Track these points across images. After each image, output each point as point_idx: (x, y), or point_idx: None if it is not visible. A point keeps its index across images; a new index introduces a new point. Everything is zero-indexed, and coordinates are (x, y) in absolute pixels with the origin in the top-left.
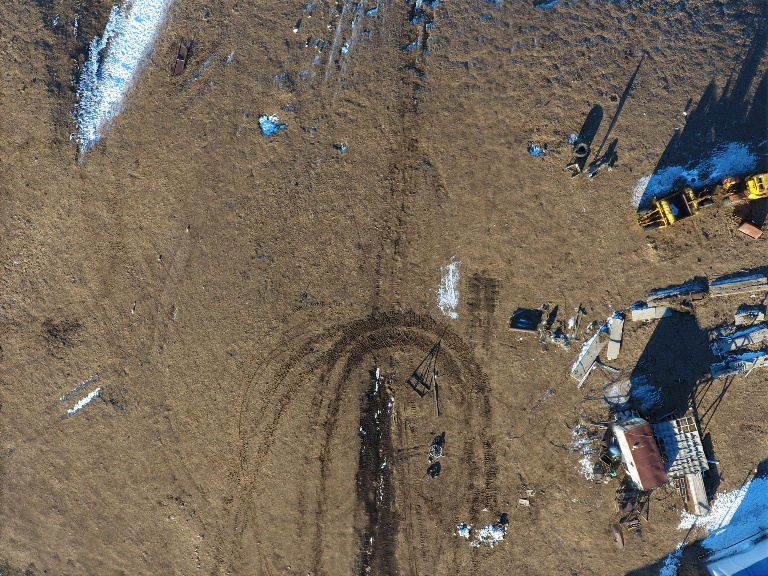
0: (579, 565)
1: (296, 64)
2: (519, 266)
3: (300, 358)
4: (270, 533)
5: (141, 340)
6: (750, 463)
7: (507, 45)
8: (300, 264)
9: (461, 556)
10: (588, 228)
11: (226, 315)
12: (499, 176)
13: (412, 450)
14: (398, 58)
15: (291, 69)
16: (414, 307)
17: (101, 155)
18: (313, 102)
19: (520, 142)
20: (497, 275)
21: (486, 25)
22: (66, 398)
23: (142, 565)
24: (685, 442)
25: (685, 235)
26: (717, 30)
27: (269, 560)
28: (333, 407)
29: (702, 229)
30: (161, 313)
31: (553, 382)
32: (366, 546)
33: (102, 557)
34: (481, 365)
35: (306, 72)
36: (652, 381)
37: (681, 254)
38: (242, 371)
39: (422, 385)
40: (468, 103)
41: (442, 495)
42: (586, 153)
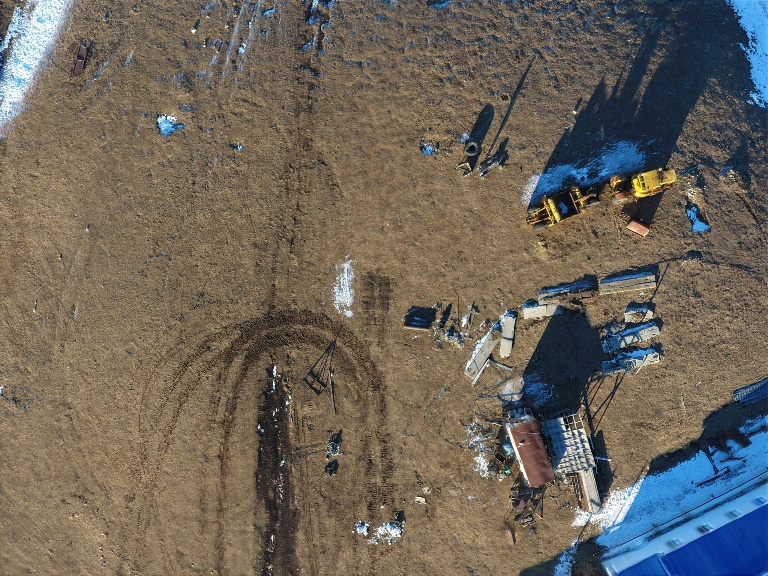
0: (475, 562)
1: (194, 64)
2: (413, 264)
3: (198, 356)
4: (173, 531)
5: (43, 339)
6: (642, 460)
7: (401, 45)
8: (197, 263)
9: (360, 554)
10: (480, 226)
11: (125, 314)
12: (392, 175)
13: (310, 448)
14: (294, 58)
15: (189, 69)
16: (310, 305)
17: (2, 155)
18: (210, 102)
19: (413, 141)
20: (391, 273)
21: (380, 25)
22: None
23: (48, 563)
24: (572, 439)
25: (575, 233)
26: (608, 29)
27: (173, 558)
28: (231, 405)
29: (591, 227)
30: (62, 312)
31: (448, 380)
32: (267, 544)
33: (8, 555)
34: (376, 363)
35: (204, 72)
36: (545, 379)
37: (571, 252)
38: (141, 369)
39: (318, 383)
40: (362, 102)
41: (340, 493)
42: (476, 152)
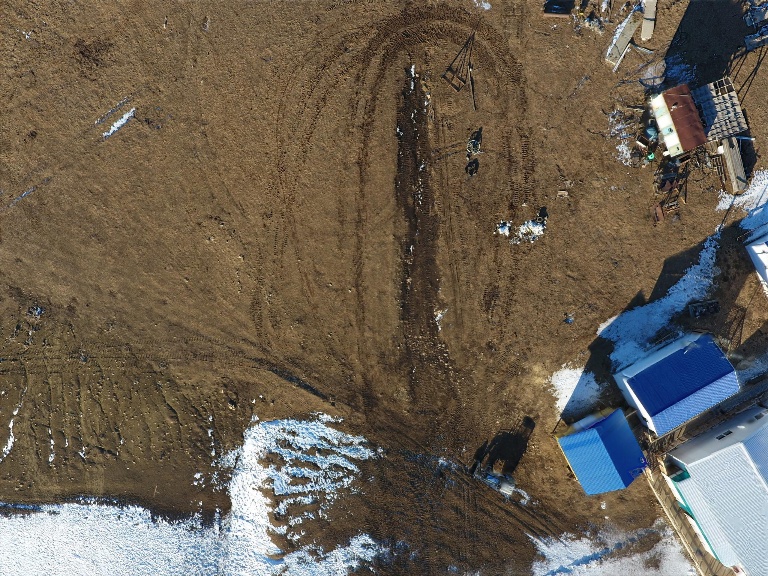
0: (619, 253)
1: None
2: None
3: (335, 58)
4: (310, 248)
5: (174, 55)
6: None
7: None
8: None
9: (501, 255)
10: None
11: (259, 20)
12: None
13: (450, 148)
14: None
15: None
16: None
17: None
18: None
19: None
20: None
21: None
22: (101, 121)
23: (184, 292)
24: (723, 104)
25: None
26: None
27: (310, 278)
28: (370, 107)
29: None
30: (193, 25)
31: (588, 68)
32: (406, 255)
33: (143, 286)
34: (516, 55)
35: None
36: (687, 59)
37: None
38: (277, 76)
39: (458, 79)
40: None
41: (481, 193)
42: None
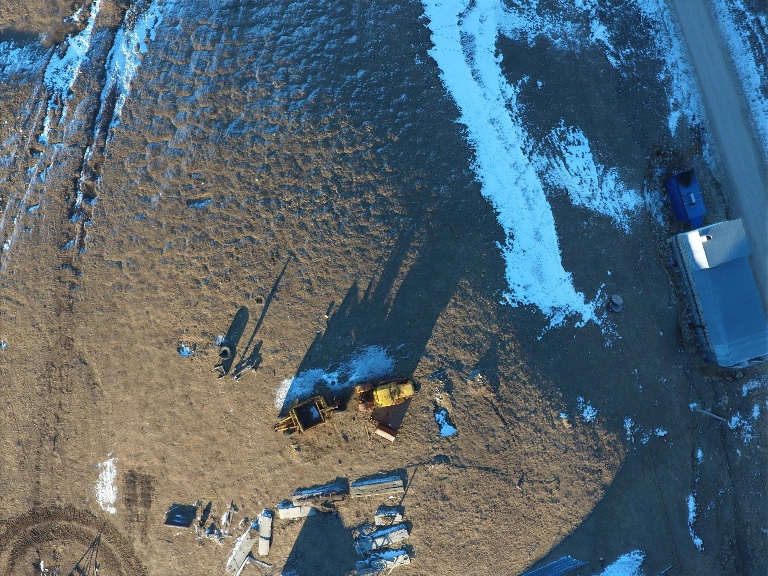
0: None
1: None
2: (173, 463)
3: None
4: None
5: None
6: None
7: (159, 245)
8: None
9: None
10: (236, 428)
11: None
12: (151, 376)
13: None
14: (56, 256)
15: None
16: (74, 502)
17: None
18: None
19: (170, 342)
20: (152, 472)
21: (140, 224)
22: None
23: None
24: None
25: (326, 437)
26: (362, 231)
27: None
28: None
29: (342, 431)
30: None
31: (210, 575)
32: None
33: None
34: (140, 559)
35: None
36: None
37: (323, 455)
38: None
39: None
40: (121, 303)
41: None
42: (228, 357)
